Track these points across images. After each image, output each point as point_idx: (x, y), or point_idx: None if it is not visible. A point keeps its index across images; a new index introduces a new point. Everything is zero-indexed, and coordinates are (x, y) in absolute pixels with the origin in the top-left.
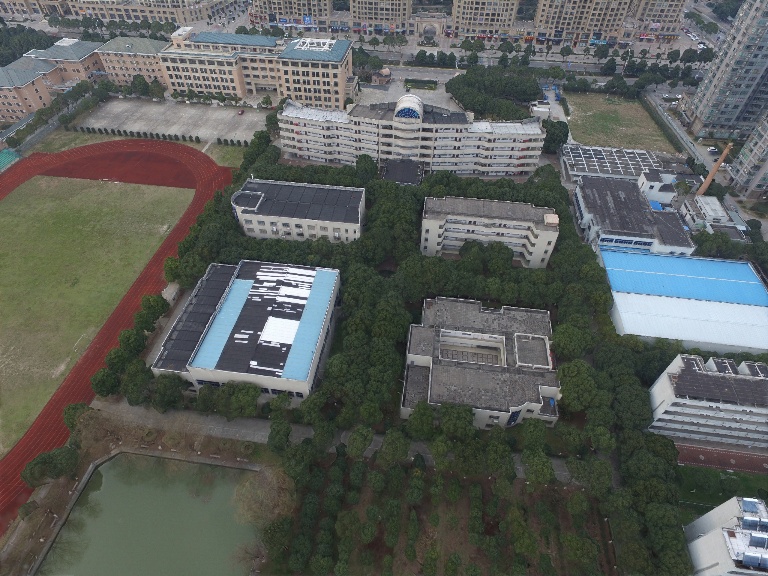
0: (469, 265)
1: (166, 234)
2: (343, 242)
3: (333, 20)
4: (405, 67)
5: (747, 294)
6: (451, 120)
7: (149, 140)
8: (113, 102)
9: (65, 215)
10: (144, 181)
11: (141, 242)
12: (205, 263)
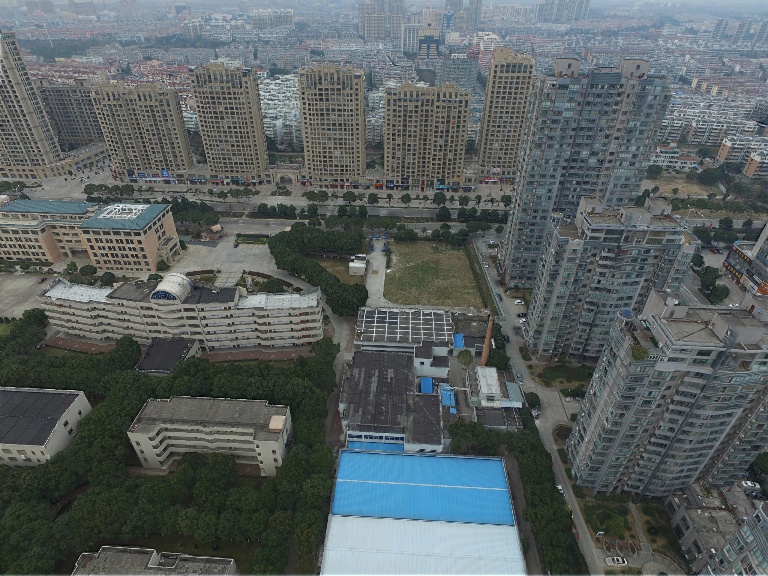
0: (165, 492)
1: None
2: (27, 467)
3: (190, 173)
4: (247, 219)
5: (488, 507)
6: (218, 297)
7: None
8: None
9: None
10: None
11: None
12: None
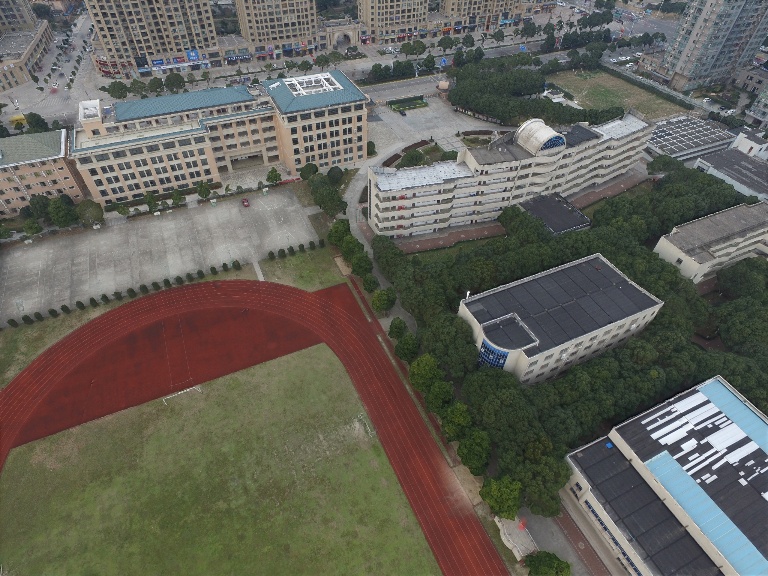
0: None
1: (373, 436)
2: (648, 333)
3: (228, 49)
4: (364, 88)
5: None
6: (578, 136)
7: (156, 295)
8: (11, 254)
9: (166, 498)
10: (231, 366)
11: (354, 472)
12: (557, 460)
